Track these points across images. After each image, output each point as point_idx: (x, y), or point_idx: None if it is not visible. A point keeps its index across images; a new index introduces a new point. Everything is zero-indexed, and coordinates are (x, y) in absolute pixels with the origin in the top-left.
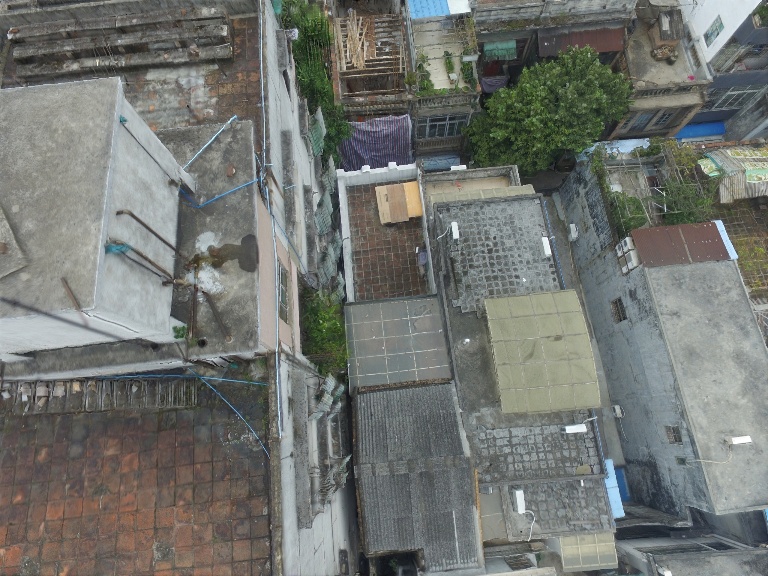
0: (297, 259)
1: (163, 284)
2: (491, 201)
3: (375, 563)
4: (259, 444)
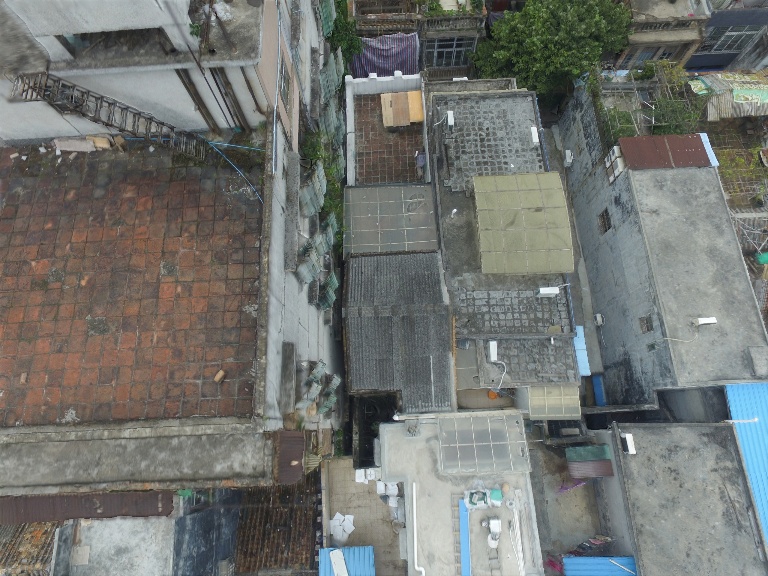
0: (300, 88)
1: None
2: (486, 96)
3: (358, 423)
4: (255, 195)
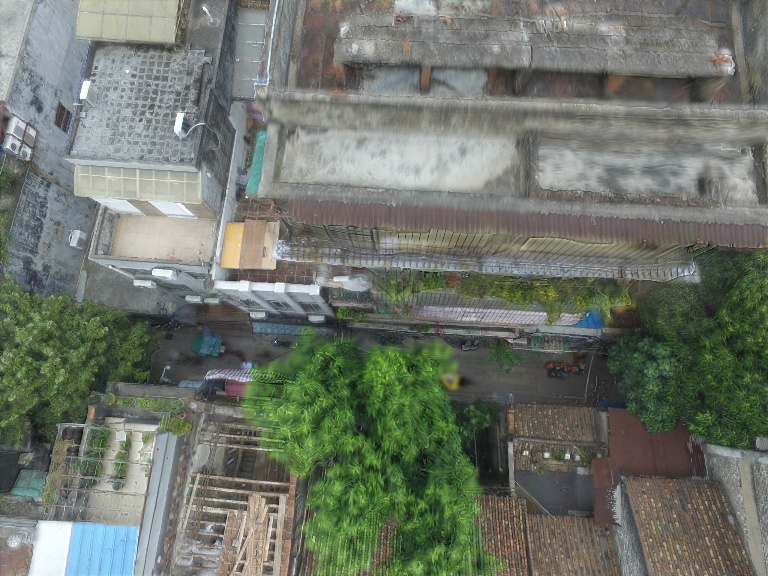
0: None
1: None
2: None
3: None
4: None
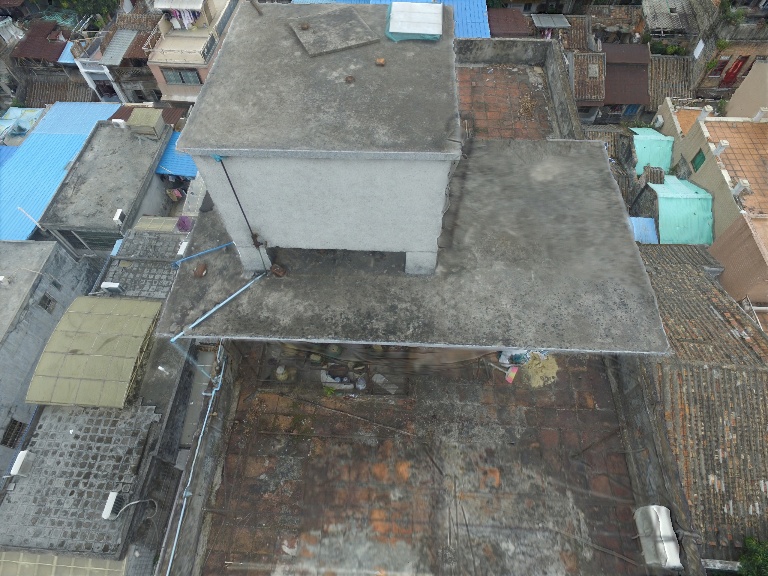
0: None
1: None
2: (44, 550)
3: None
4: None
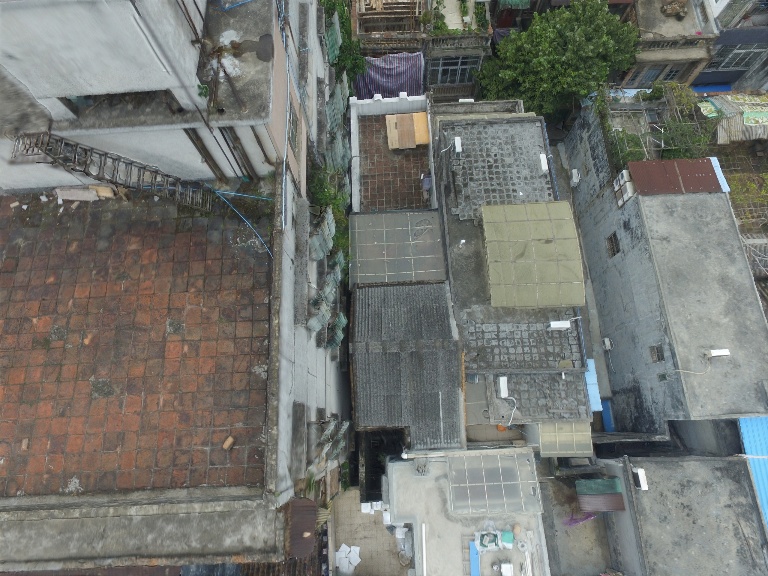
0: (307, 125)
1: (192, 43)
2: (494, 122)
3: (364, 455)
4: (264, 247)
